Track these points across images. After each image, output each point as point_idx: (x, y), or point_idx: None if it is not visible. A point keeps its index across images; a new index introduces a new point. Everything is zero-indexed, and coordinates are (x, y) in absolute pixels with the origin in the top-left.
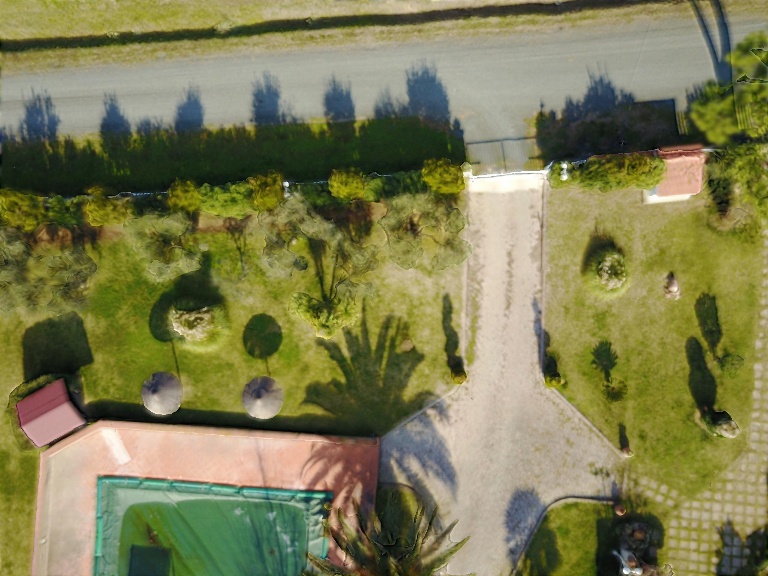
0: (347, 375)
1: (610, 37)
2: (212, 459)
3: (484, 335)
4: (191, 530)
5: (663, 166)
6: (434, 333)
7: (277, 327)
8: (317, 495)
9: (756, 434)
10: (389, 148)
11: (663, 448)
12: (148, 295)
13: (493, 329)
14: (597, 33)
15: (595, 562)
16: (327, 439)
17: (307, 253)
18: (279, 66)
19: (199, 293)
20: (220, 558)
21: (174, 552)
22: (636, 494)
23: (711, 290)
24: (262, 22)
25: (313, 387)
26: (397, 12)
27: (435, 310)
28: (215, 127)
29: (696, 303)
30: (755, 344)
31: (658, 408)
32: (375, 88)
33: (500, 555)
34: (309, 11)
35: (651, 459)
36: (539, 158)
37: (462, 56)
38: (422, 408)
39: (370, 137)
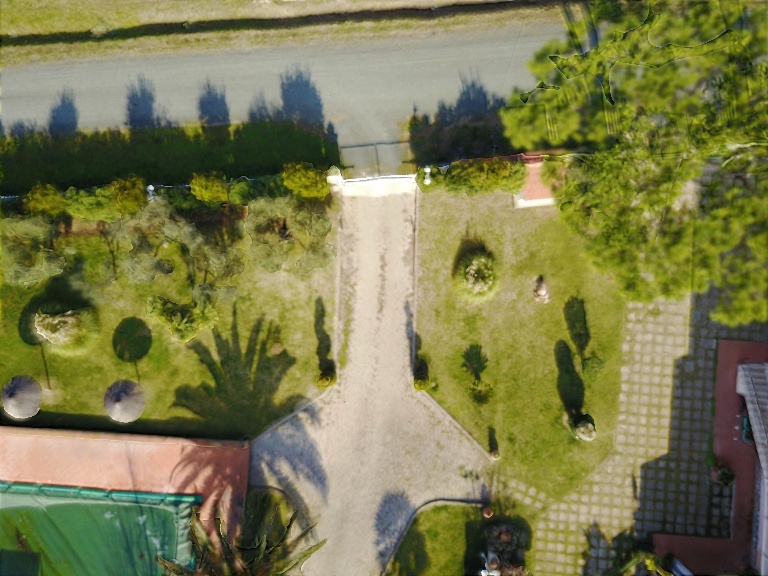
0: (217, 378)
1: (482, 42)
2: (81, 463)
3: (357, 338)
4: (60, 534)
5: (524, 170)
6: (306, 336)
7: (147, 330)
8: (186, 498)
9: (622, 436)
10: (263, 152)
11: (531, 451)
12: (19, 298)
13: (366, 332)
14: (469, 38)
15: (463, 564)
16: (194, 442)
17: (179, 256)
18: (154, 70)
19: (69, 296)
20: (89, 562)
21: (43, 556)
22: (505, 496)
23: (580, 293)
24: (140, 26)
25: (182, 390)
26: (274, 16)
27: (307, 313)
28: (90, 130)
29: (565, 306)
30: (622, 347)
31: (527, 411)
32: (250, 92)
33: (370, 558)
34: (186, 15)
35: (520, 462)
36: (412, 162)
37: (336, 60)
38: (293, 411)
39: (245, 141)
